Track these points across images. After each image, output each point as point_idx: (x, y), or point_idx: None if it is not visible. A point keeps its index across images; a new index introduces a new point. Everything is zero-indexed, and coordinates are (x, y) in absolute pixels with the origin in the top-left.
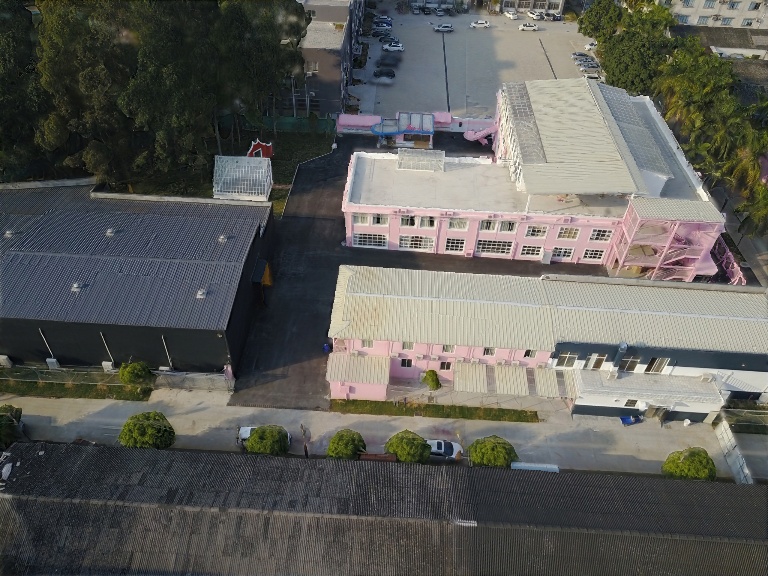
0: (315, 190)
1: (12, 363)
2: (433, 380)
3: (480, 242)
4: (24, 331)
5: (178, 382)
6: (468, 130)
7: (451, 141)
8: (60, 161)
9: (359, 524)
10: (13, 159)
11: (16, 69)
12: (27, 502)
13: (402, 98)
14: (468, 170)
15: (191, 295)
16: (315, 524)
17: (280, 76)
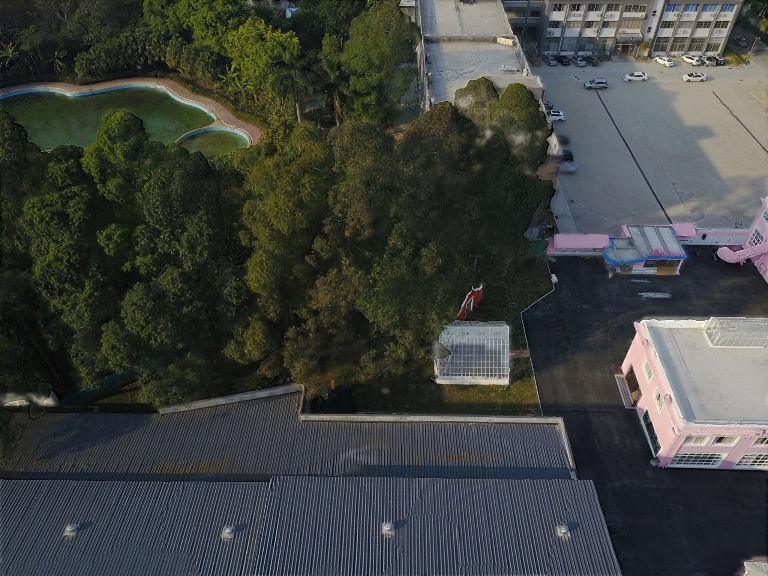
0: (563, 358)
1: None
2: None
3: None
4: None
5: None
6: (712, 242)
7: (697, 261)
8: None
9: None
10: (192, 376)
11: (207, 262)
12: None
13: (597, 192)
14: None
15: None
16: None
17: None
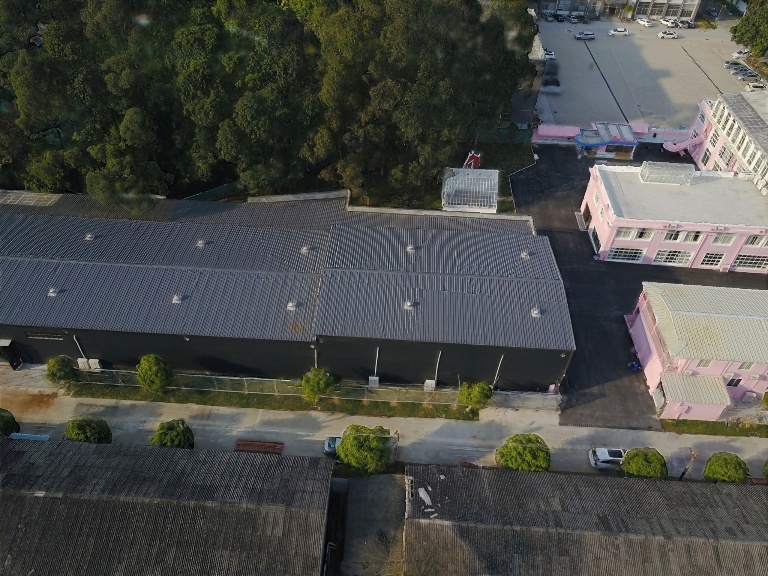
0: (538, 202)
1: None
2: None
3: (739, 257)
4: (360, 350)
5: (503, 401)
6: (661, 141)
7: (648, 152)
8: (294, 173)
9: None
10: (274, 172)
11: (294, 83)
12: (468, 529)
13: (576, 107)
14: (713, 183)
15: (526, 314)
16: (765, 552)
17: None
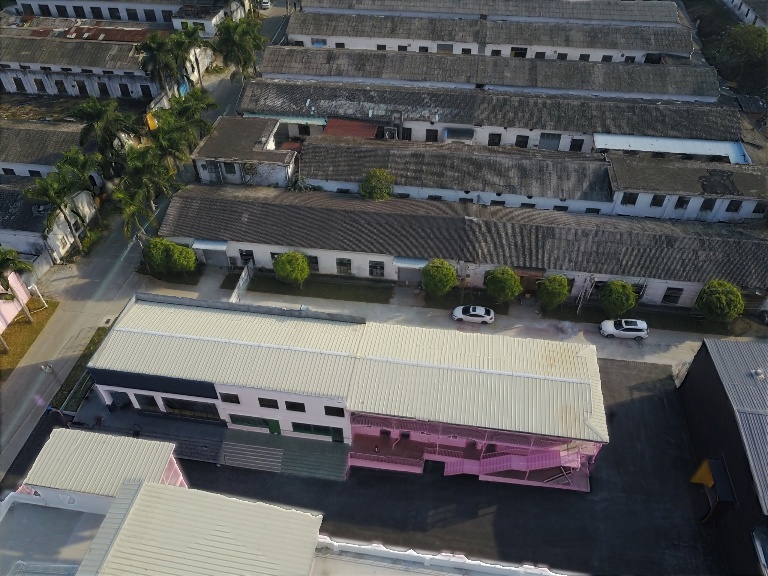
0: None
1: None
2: None
3: None
4: None
5: None
6: None
7: None
8: None
9: (539, 223)
10: None
11: None
12: None
13: None
14: None
15: None
16: None
17: None
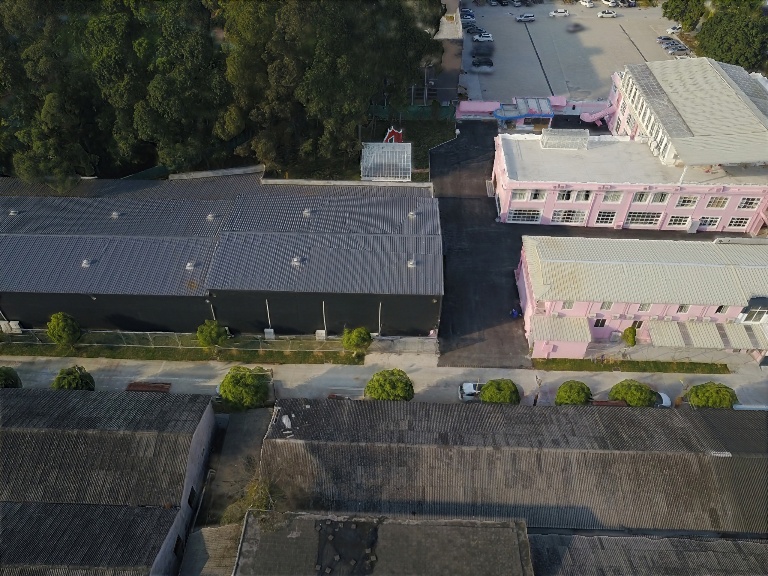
0: (453, 173)
1: None
2: (633, 336)
3: (630, 214)
4: (251, 303)
5: (387, 347)
6: (580, 113)
7: (567, 123)
8: (218, 152)
9: (623, 458)
10: (191, 150)
11: (201, 65)
12: (319, 446)
13: (505, 85)
14: (609, 147)
15: (402, 265)
16: (583, 458)
17: (419, 65)
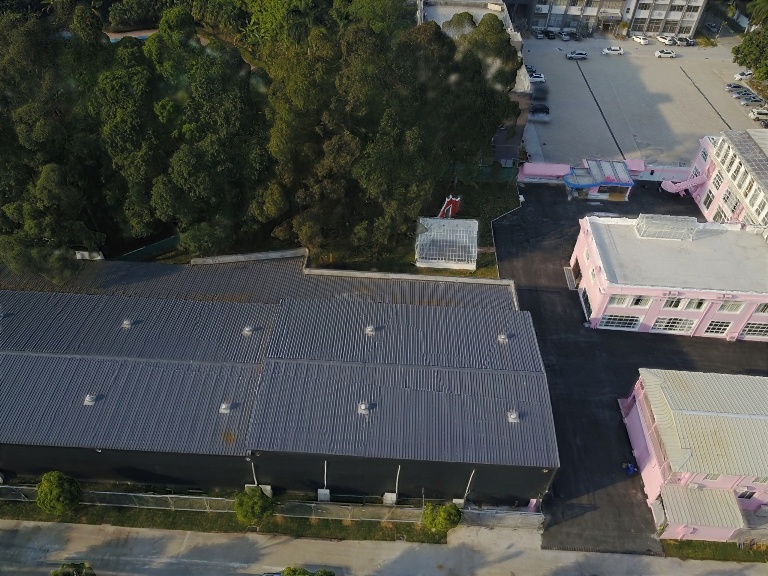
0: (523, 254)
1: (272, 492)
2: None
3: (748, 325)
4: (305, 463)
5: (475, 517)
6: (659, 178)
7: (645, 191)
8: None
9: None
10: (219, 232)
11: (239, 133)
12: None
13: (566, 138)
14: (718, 238)
15: (501, 418)
16: None
17: None
